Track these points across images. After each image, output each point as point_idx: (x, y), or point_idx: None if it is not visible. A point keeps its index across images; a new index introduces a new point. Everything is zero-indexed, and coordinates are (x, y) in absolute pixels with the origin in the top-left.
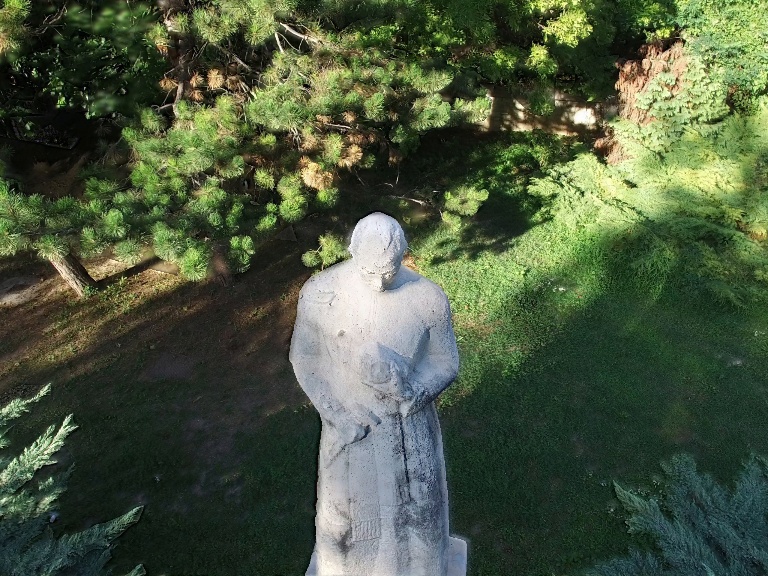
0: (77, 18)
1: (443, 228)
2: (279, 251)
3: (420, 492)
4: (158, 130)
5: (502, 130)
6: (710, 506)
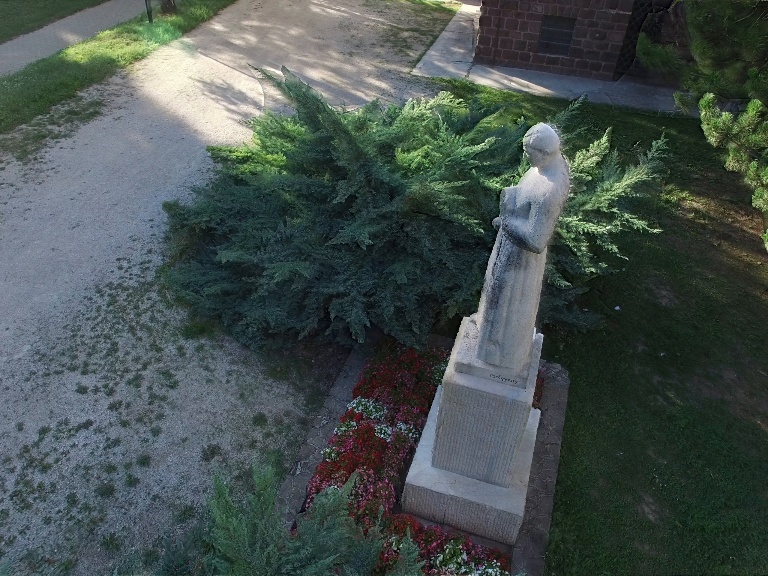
0: None
1: None
2: None
3: None
4: None
5: None
6: None
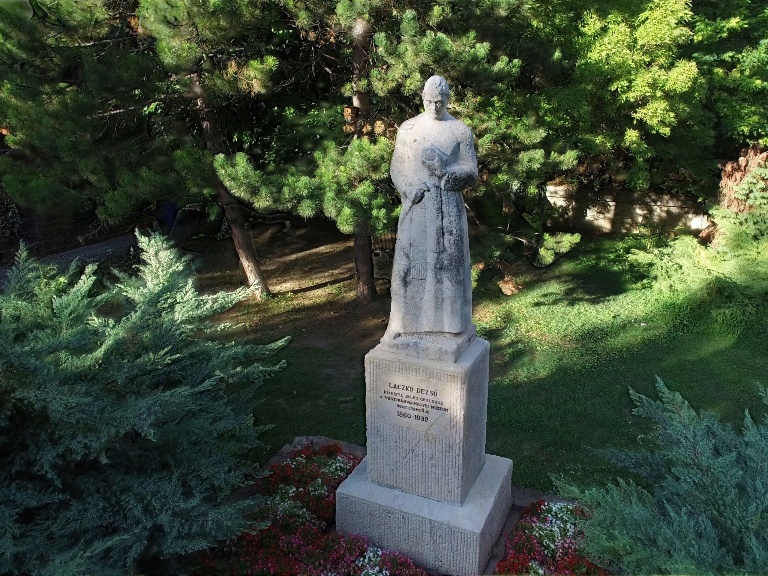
0: (299, 85)
1: (539, 259)
2: None
3: (450, 243)
4: None
5: (623, 232)
6: None
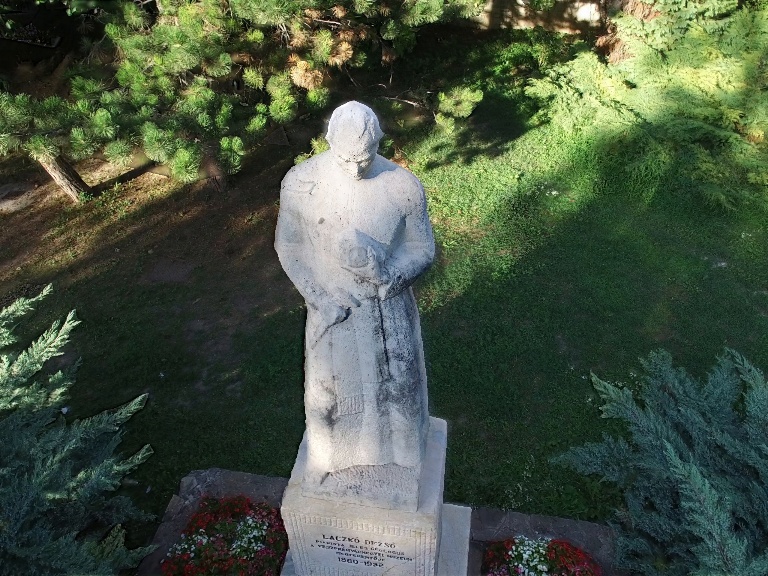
0: None
1: (437, 131)
2: (273, 156)
3: (399, 371)
4: (142, 27)
5: (502, 28)
6: (682, 395)
